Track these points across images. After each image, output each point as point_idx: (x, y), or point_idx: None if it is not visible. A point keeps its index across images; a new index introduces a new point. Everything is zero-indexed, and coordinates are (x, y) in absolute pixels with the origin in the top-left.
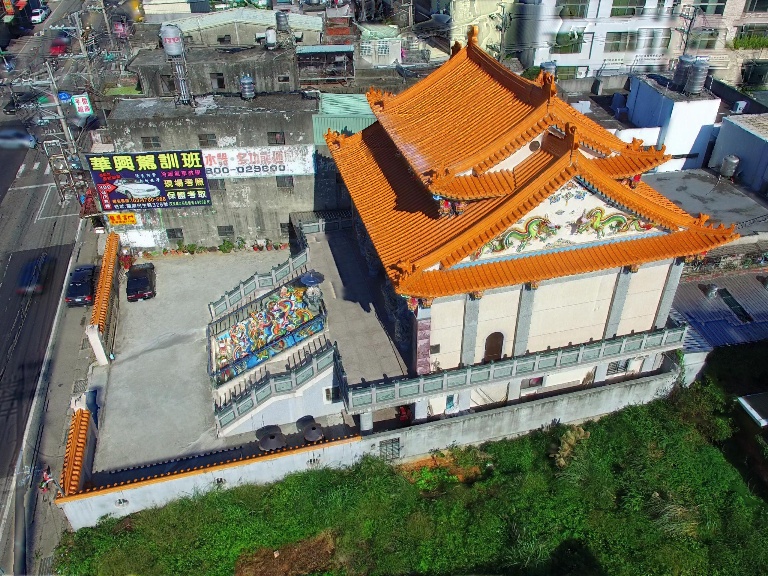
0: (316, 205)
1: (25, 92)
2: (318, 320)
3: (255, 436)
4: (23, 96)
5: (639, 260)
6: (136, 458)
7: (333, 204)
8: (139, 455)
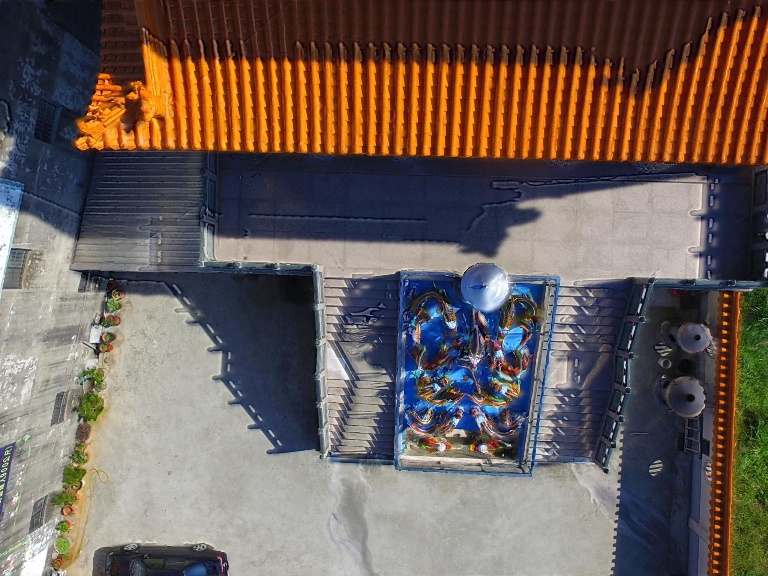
0: (72, 207)
1: None
2: (556, 295)
3: None
4: None
5: None
6: (596, 574)
7: (80, 168)
8: (592, 571)
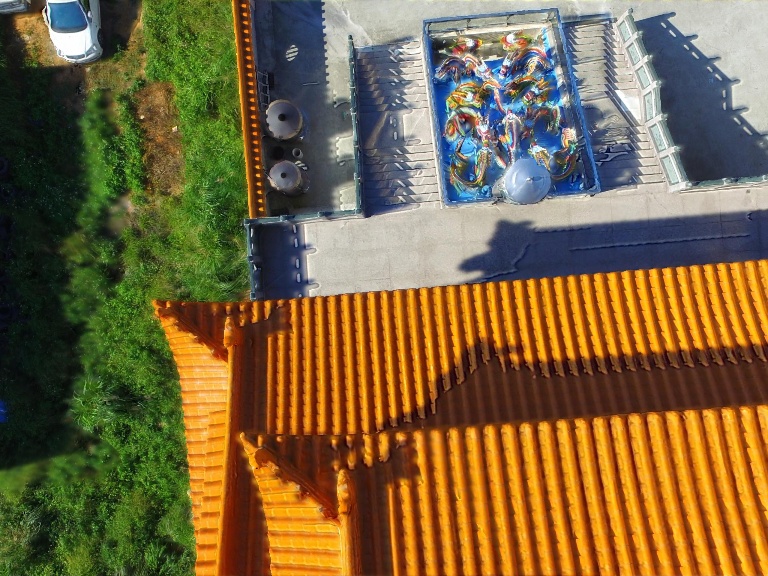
0: None
1: None
2: (445, 188)
3: (343, 101)
4: None
5: None
6: None
7: None
8: None
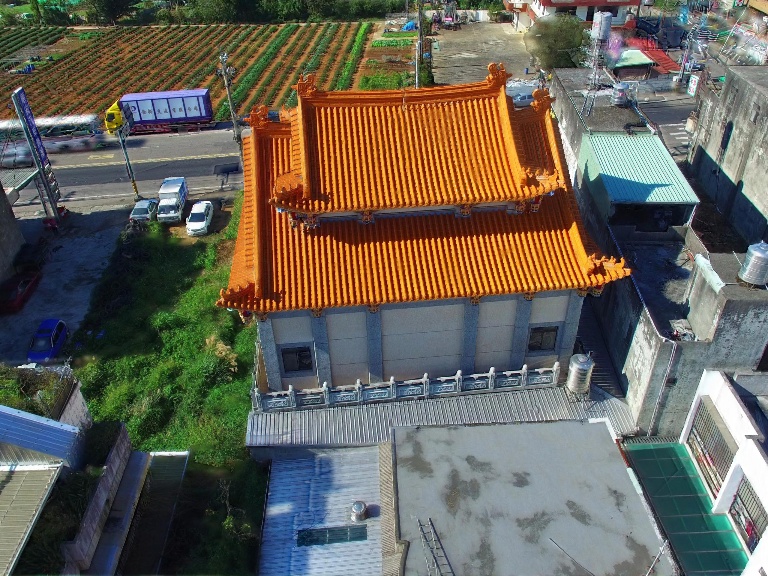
0: None
1: (586, 38)
2: None
3: None
4: (584, 40)
5: (235, 253)
6: None
7: None
8: None
